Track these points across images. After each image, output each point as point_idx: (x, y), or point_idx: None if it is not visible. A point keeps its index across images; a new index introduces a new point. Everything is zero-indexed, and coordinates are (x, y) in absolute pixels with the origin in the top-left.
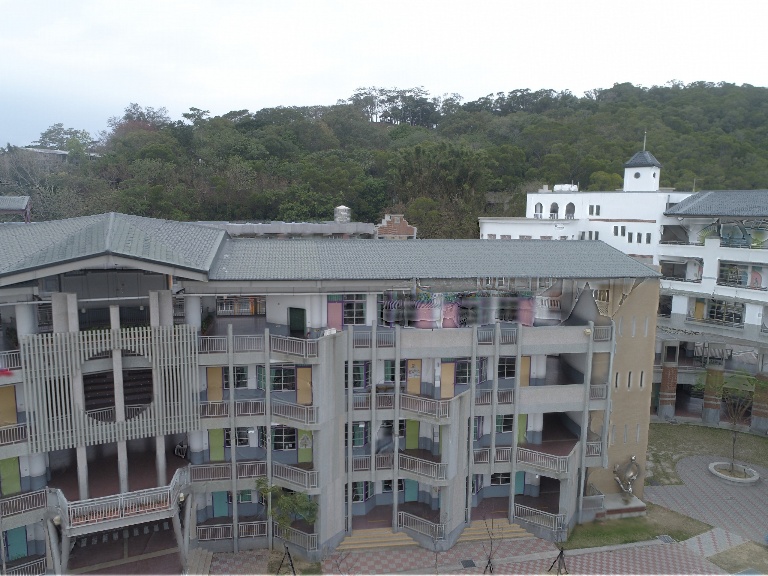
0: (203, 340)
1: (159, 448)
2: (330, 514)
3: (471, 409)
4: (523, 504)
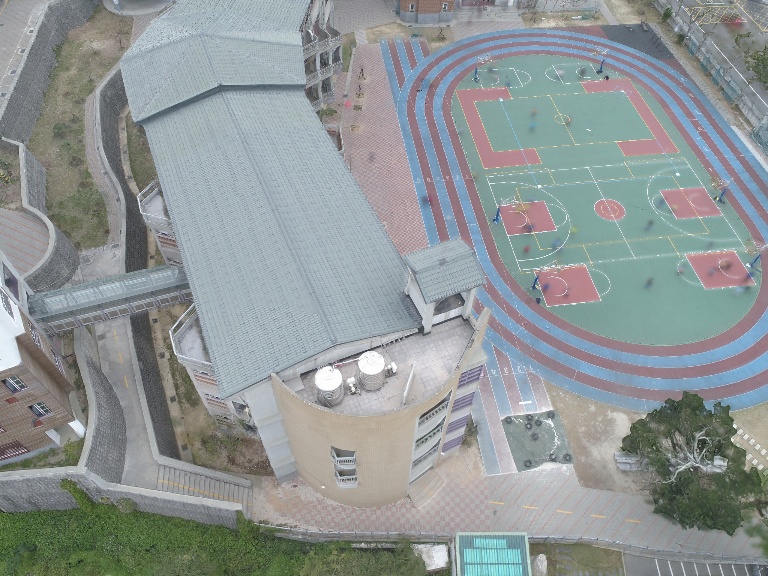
0: None
1: None
2: None
3: None
4: None
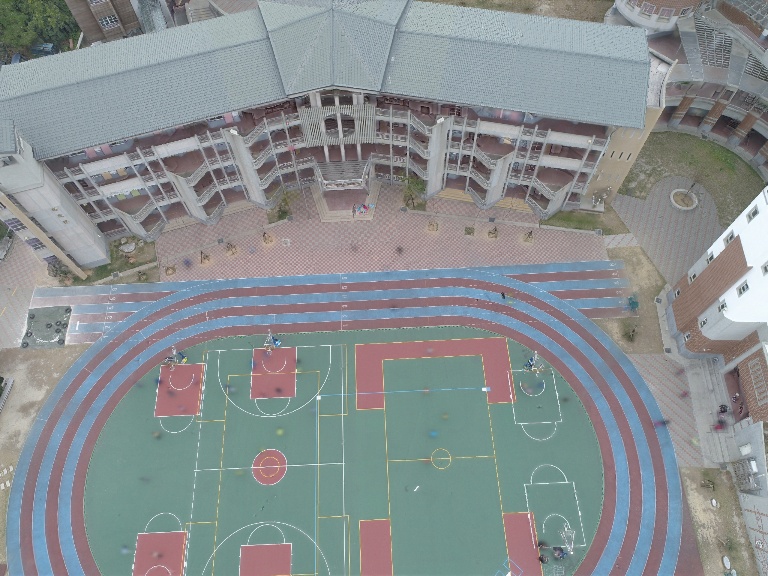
0: (378, 110)
1: (358, 147)
2: (433, 185)
3: (513, 160)
4: (532, 198)
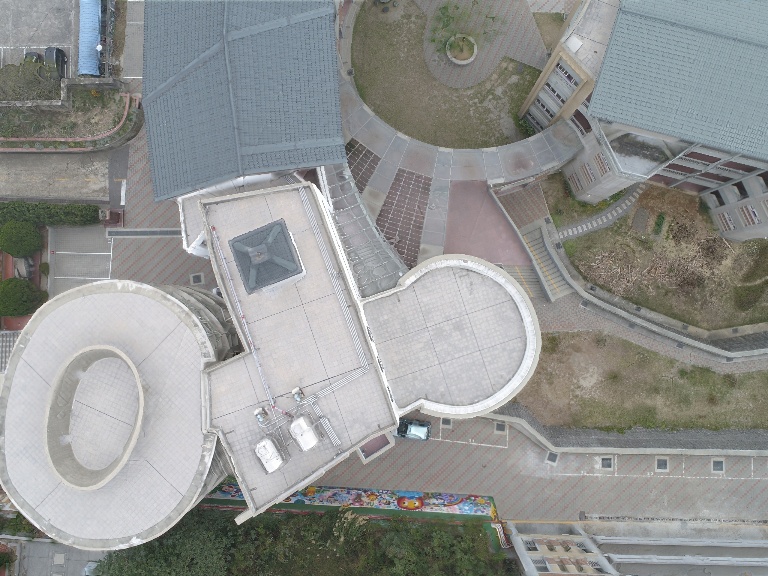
0: None
1: None
2: None
3: None
4: None
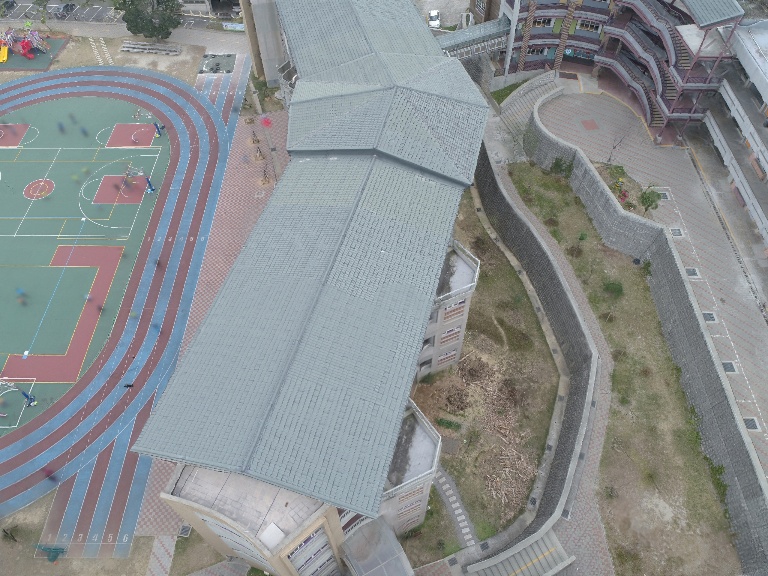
0: None
1: None
2: None
3: None
4: None
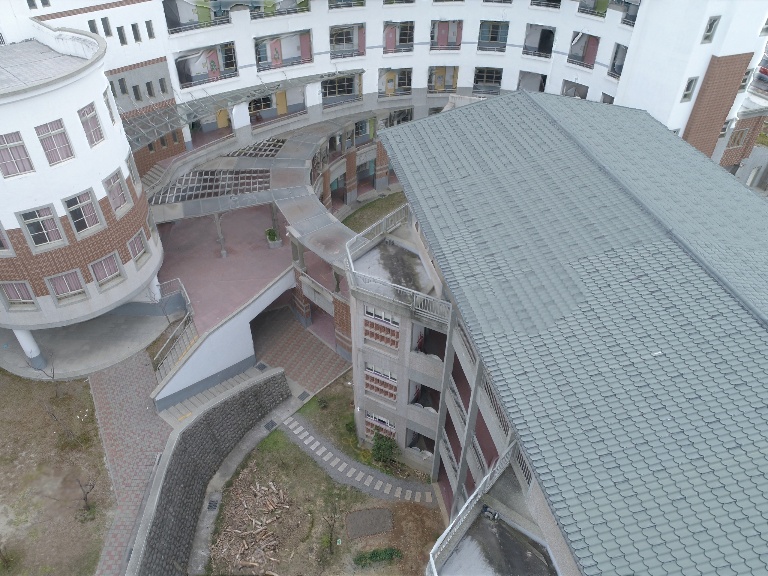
0: None
1: None
2: None
3: None
4: None
